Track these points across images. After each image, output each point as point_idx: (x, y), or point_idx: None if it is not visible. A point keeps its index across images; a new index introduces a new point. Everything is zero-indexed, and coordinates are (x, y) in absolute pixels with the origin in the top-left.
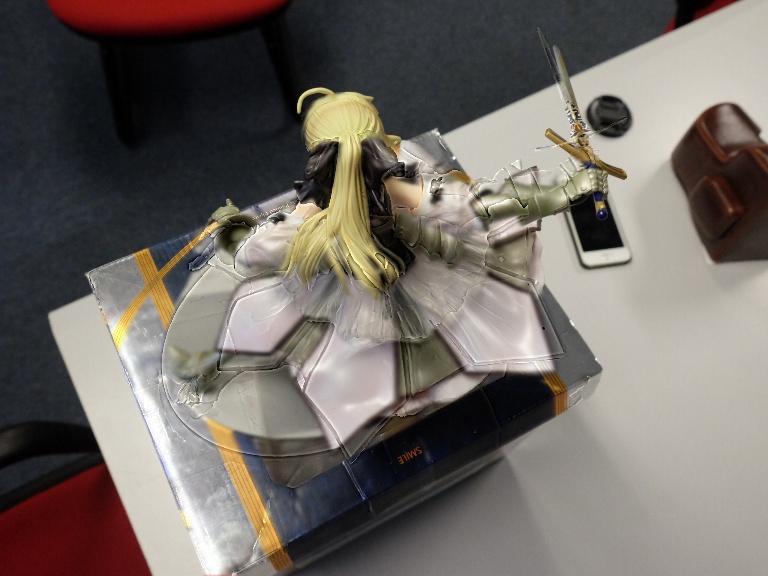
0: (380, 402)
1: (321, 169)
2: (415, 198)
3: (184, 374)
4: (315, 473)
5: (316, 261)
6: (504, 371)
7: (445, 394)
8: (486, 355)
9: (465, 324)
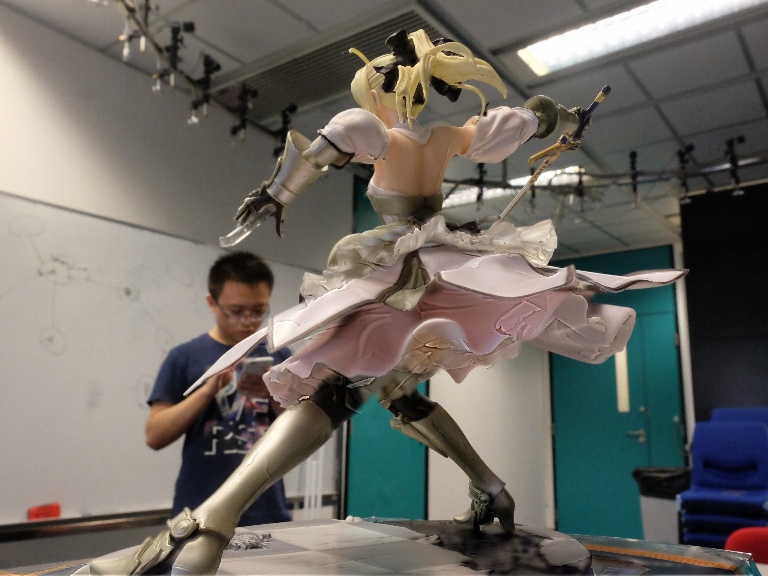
0: None
1: None
2: (470, 127)
3: None
4: None
5: (428, 60)
6: (645, 569)
7: (609, 327)
8: None
9: None
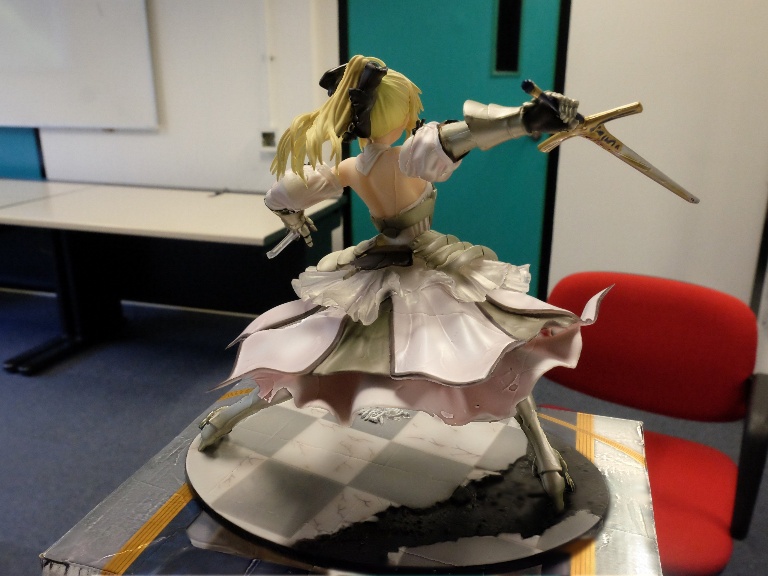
0: (282, 364)
1: (331, 74)
2: None
3: None
4: (224, 551)
5: (288, 137)
6: None
7: None
8: (409, 366)
9: (415, 337)
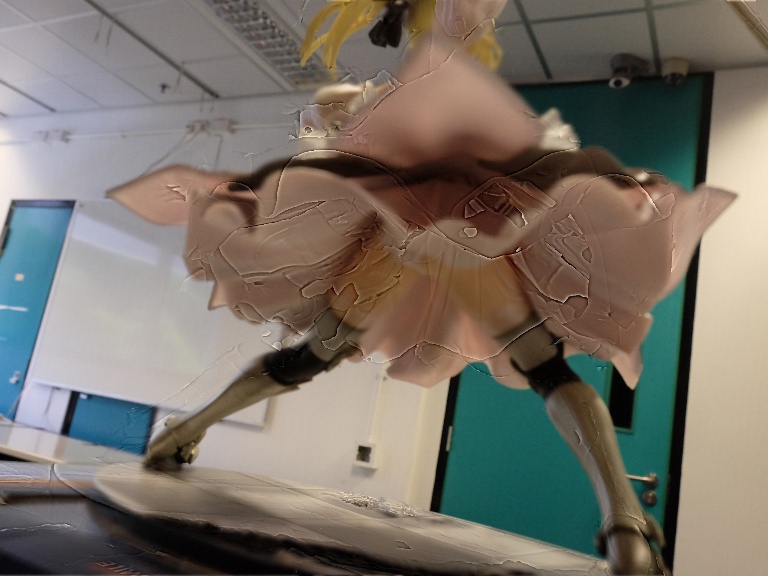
0: None
1: None
2: None
3: (159, 463)
4: None
5: None
6: None
7: None
8: None
9: None
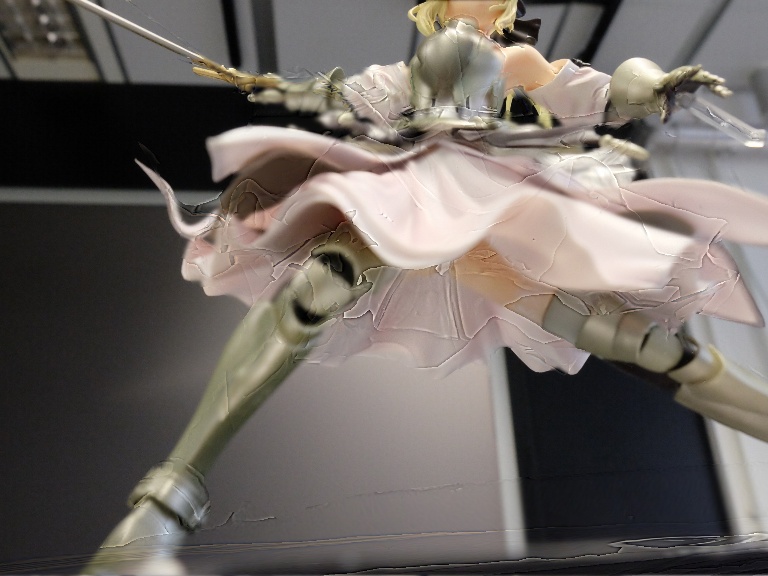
0: None
1: None
2: None
3: None
4: None
5: None
6: None
7: None
8: None
9: None
